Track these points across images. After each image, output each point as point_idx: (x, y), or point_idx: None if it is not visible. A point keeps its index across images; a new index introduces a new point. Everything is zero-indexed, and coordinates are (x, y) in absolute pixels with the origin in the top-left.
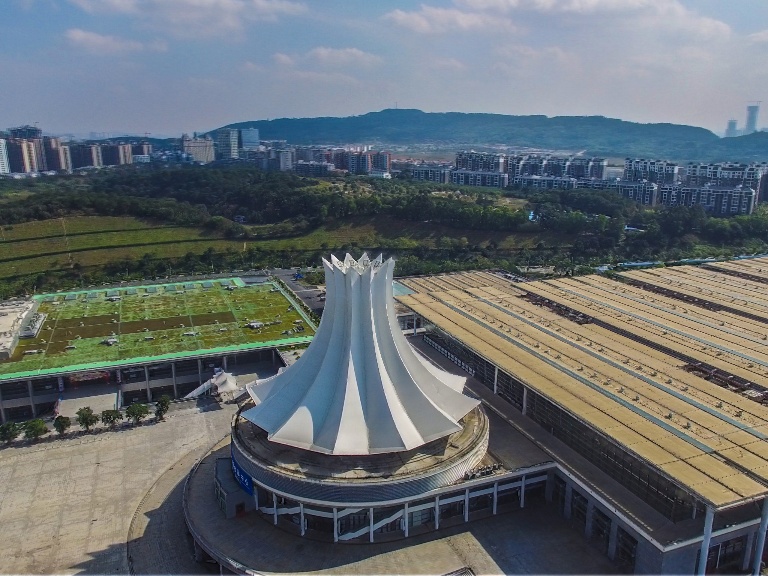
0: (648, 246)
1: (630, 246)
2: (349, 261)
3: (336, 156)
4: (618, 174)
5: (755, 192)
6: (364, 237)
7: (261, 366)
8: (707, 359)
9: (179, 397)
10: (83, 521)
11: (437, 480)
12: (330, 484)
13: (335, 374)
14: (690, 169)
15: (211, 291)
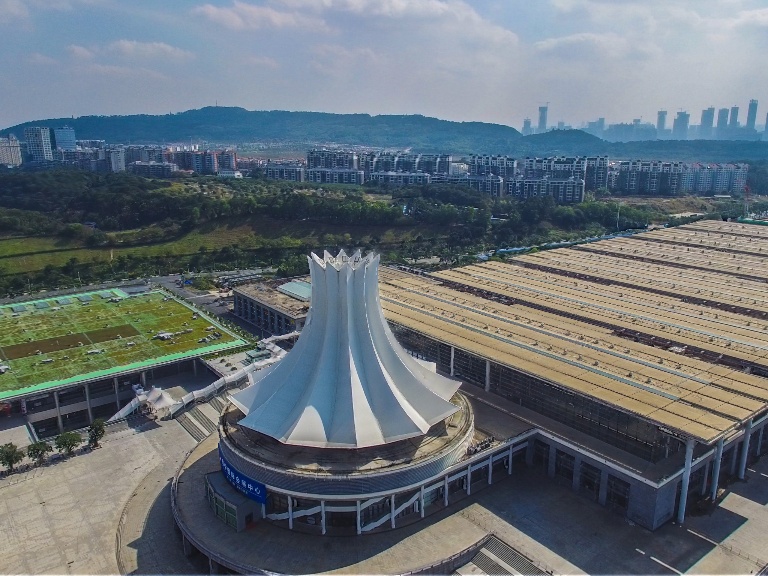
0: (512, 233)
1: (497, 234)
2: (328, 258)
3: (177, 156)
4: (463, 169)
5: (584, 182)
6: (245, 238)
7: (182, 378)
8: (628, 325)
9: None
10: (57, 566)
11: (450, 459)
12: (358, 477)
13: (334, 371)
14: (527, 163)
15: (93, 305)
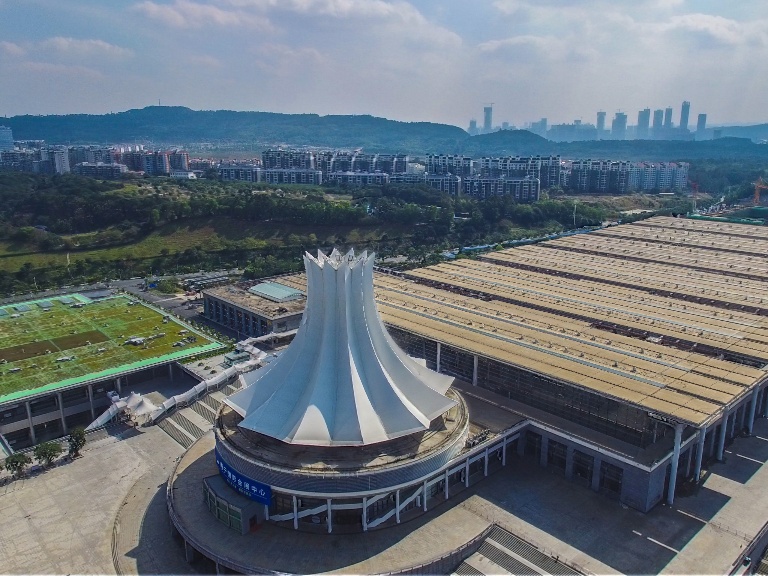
0: (475, 232)
1: (460, 233)
2: (322, 257)
3: (125, 157)
4: (420, 169)
5: None
6: (208, 240)
7: (158, 383)
8: (604, 318)
9: (68, 431)
10: None
11: (451, 452)
12: (365, 474)
13: (333, 369)
14: (483, 163)
15: (55, 311)
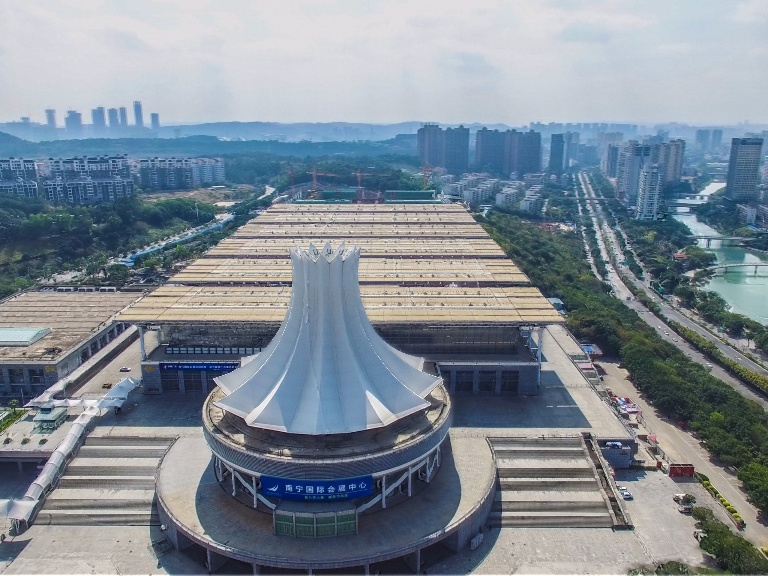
0: (119, 237)
1: (104, 240)
2: None
3: None
4: None
5: None
6: None
7: None
8: (402, 279)
9: None
10: None
11: None
12: (438, 428)
13: (356, 356)
14: (53, 164)
15: None
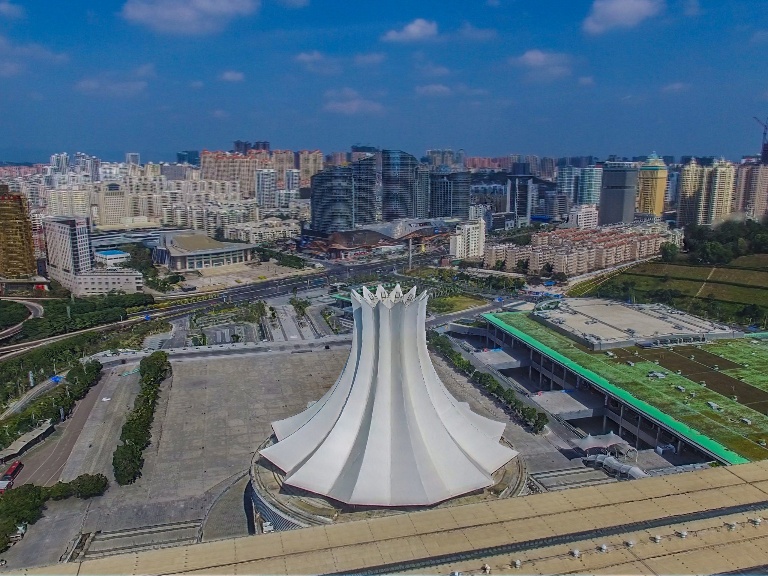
0: None
1: None
2: None
3: None
4: None
5: None
6: None
7: None
8: None
9: None
10: None
11: None
12: None
13: None
14: None
15: None
